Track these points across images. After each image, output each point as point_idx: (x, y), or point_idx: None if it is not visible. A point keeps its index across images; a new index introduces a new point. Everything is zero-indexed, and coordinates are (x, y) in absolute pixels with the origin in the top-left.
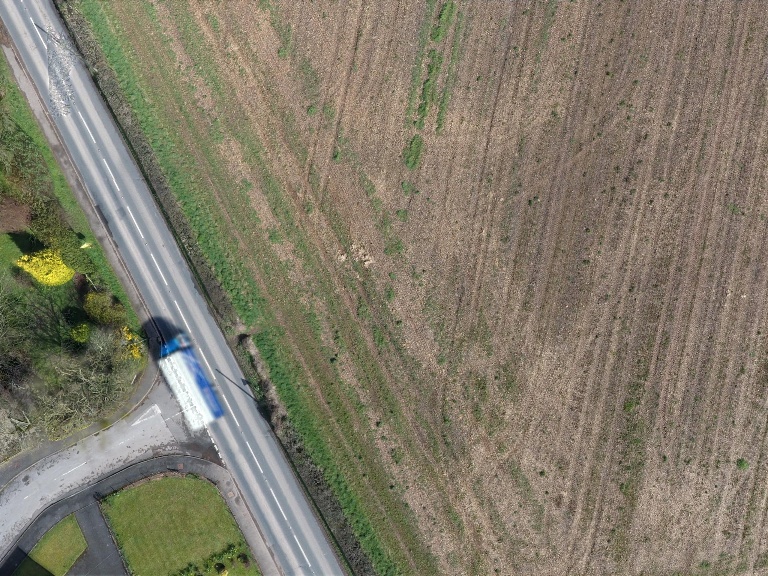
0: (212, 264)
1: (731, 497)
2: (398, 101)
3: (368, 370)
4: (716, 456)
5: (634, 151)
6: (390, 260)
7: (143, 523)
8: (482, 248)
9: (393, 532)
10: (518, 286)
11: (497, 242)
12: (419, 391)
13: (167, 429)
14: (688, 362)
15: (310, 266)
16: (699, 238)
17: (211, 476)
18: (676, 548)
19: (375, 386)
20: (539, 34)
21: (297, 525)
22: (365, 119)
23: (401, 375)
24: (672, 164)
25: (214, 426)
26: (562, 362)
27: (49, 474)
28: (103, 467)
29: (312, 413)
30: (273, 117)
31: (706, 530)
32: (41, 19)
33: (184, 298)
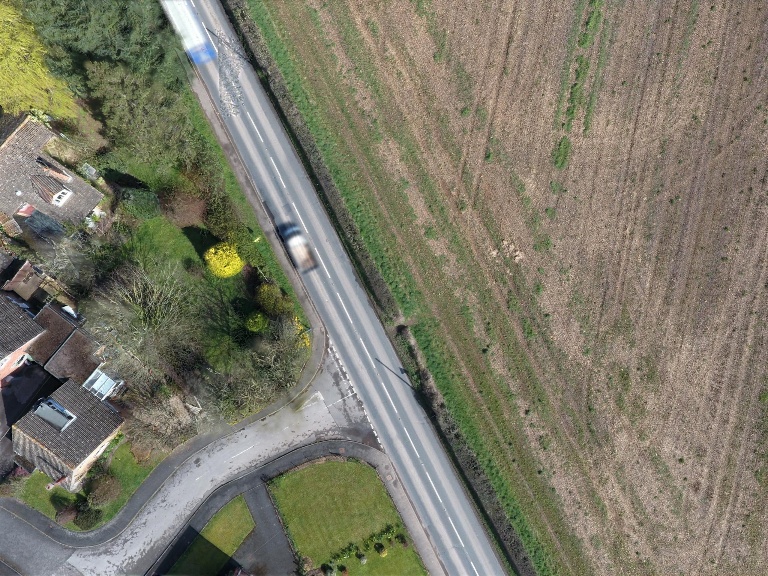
0: (373, 258)
1: None
2: (547, 104)
3: (518, 360)
4: None
5: None
6: (539, 256)
7: (307, 504)
8: (626, 245)
9: (541, 515)
10: (660, 281)
11: (640, 239)
12: (565, 381)
13: (329, 415)
14: None
15: (463, 261)
16: None
17: (371, 460)
18: None
19: (524, 376)
20: (681, 41)
21: (451, 507)
22: (516, 121)
23: (549, 365)
24: None
25: (373, 412)
26: (701, 354)
27: (219, 457)
28: (269, 450)
29: (465, 401)
30: (429, 118)
31: None
32: (212, 24)
33: (346, 290)
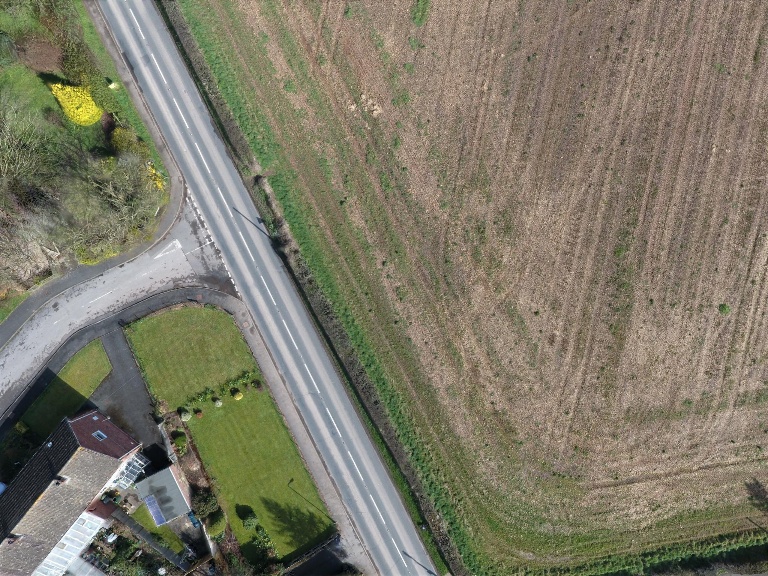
0: (230, 109)
1: (713, 340)
2: None
3: (375, 213)
4: (700, 301)
5: (627, 12)
6: (397, 110)
7: (164, 349)
8: (483, 101)
9: (397, 364)
10: (517, 137)
11: (497, 95)
12: (423, 234)
13: (187, 263)
14: (675, 212)
15: (322, 115)
16: (687, 95)
17: (228, 307)
18: (661, 386)
19: (381, 228)
20: None
21: (307, 354)
22: None
23: (406, 218)
24: (663, 25)
25: (231, 261)
26: (557, 210)
27: (77, 301)
28: (127, 296)
29: (322, 251)
30: None
31: (689, 370)
32: None
33: (204, 141)
